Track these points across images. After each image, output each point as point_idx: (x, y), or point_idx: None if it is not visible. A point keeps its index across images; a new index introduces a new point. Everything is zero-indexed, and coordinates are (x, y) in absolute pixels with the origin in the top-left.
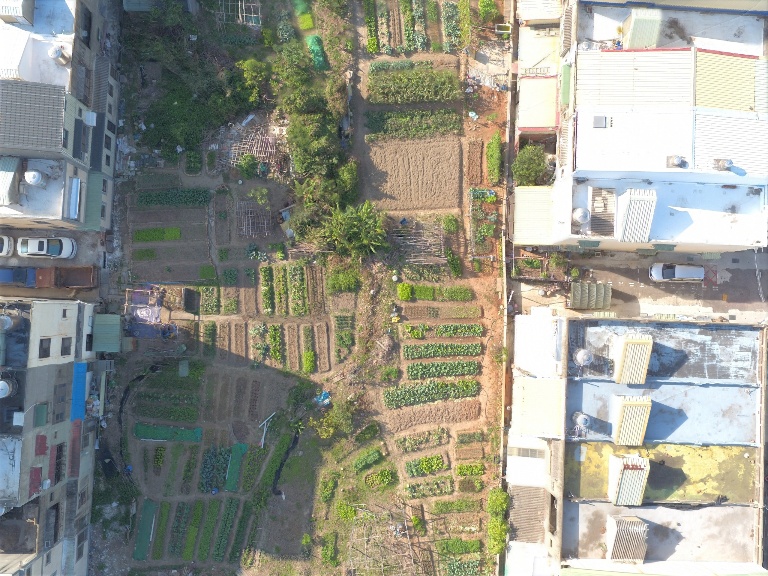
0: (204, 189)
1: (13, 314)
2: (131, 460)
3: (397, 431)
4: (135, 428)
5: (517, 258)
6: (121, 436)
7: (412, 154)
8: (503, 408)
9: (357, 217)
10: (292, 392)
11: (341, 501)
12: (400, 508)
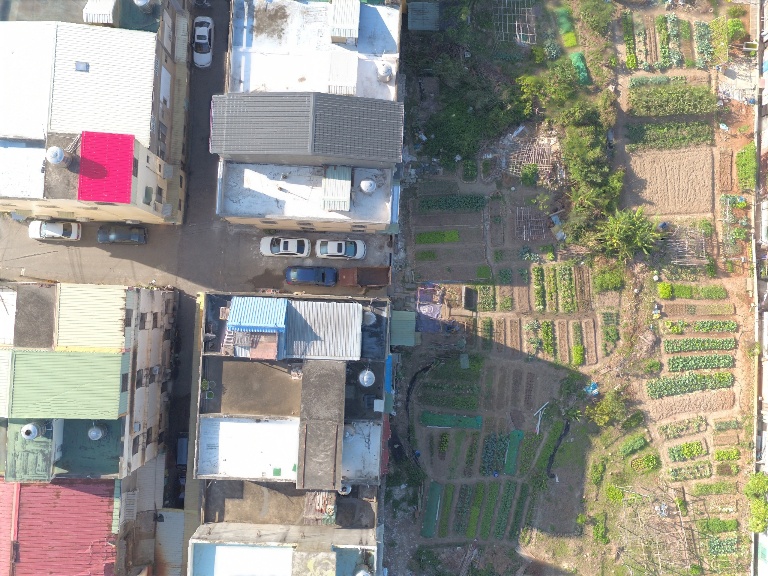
0: (480, 195)
1: (367, 310)
2: (418, 446)
3: (659, 419)
4: (421, 416)
5: (764, 259)
6: (408, 423)
7: (669, 163)
8: (756, 398)
9: (632, 221)
10: (563, 383)
11: (610, 484)
12: (663, 490)
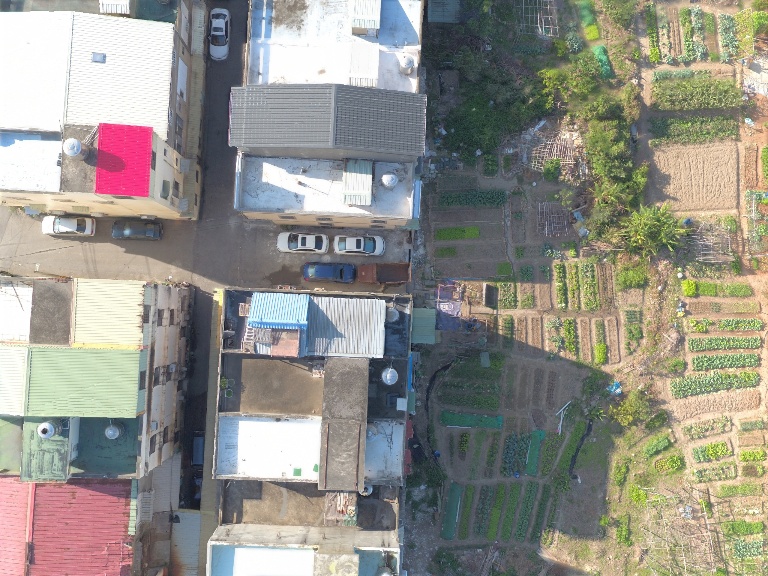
0: (501, 190)
1: (389, 307)
2: (437, 446)
3: (683, 419)
4: (441, 415)
5: None
6: (428, 423)
7: (693, 158)
8: None
9: (657, 217)
10: (586, 382)
11: (633, 485)
12: (688, 492)
